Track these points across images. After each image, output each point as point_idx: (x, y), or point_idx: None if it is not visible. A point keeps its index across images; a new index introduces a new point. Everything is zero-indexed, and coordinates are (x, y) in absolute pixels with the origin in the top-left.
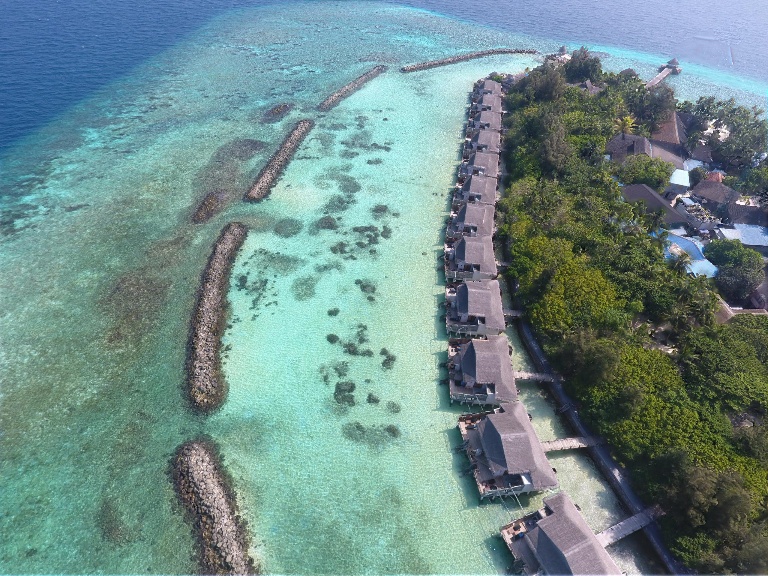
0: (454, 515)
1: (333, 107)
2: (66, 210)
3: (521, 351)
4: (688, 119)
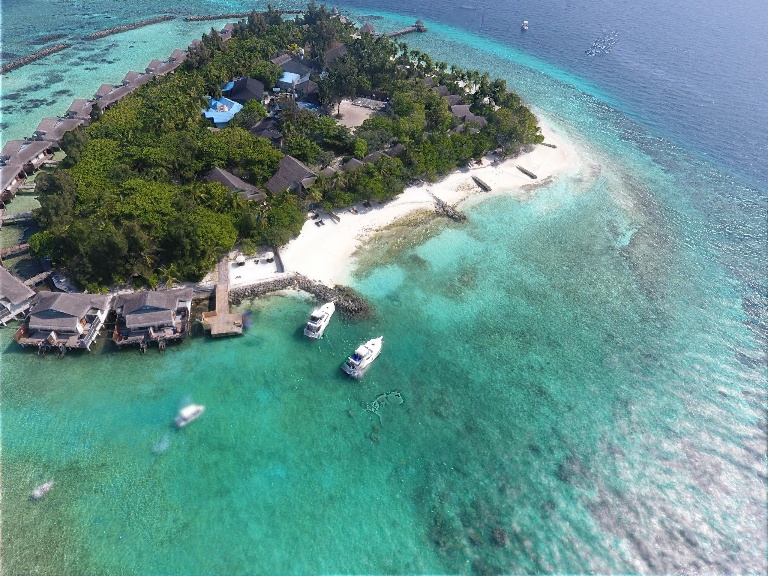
0: None
1: (98, 38)
2: None
3: None
4: None
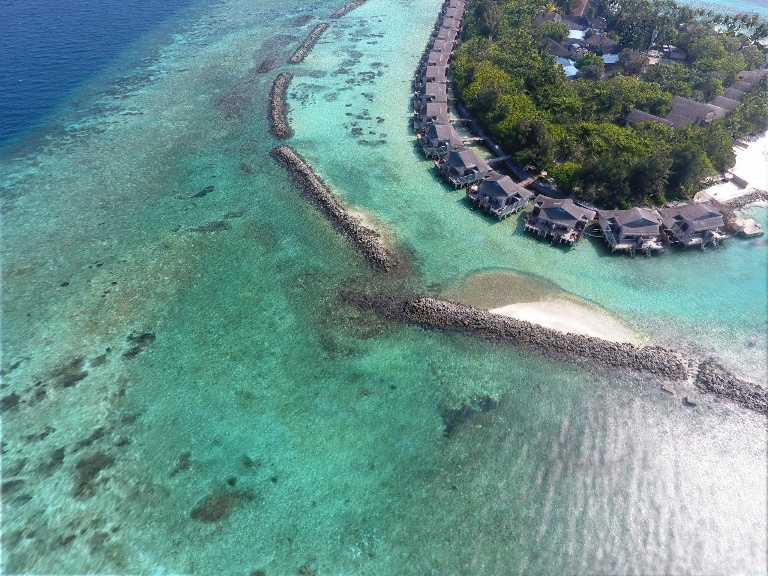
0: (413, 163)
1: (342, 16)
2: (178, 71)
3: (457, 115)
4: (596, 5)
